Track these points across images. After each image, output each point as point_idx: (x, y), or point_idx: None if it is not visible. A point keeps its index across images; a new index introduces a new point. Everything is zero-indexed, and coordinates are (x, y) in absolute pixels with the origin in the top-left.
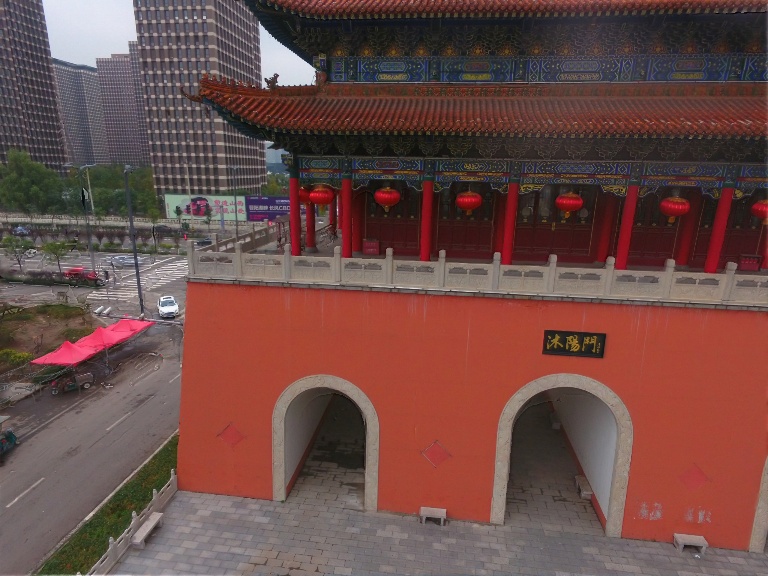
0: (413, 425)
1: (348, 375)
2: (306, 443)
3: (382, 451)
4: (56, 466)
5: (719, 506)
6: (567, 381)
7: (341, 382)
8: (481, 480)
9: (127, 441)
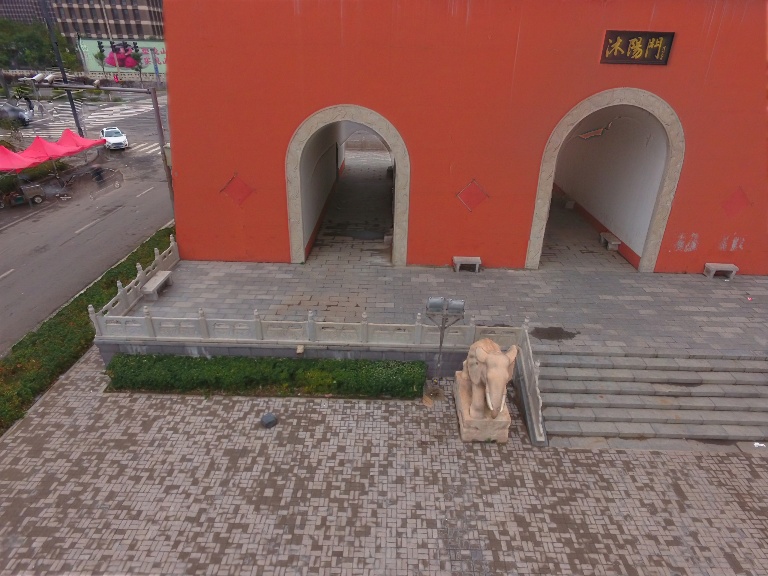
0: (448, 163)
1: (374, 104)
2: (315, 219)
3: (412, 197)
4: (25, 260)
5: (753, 232)
6: (623, 97)
7: (366, 113)
8: (519, 222)
9: (103, 239)
